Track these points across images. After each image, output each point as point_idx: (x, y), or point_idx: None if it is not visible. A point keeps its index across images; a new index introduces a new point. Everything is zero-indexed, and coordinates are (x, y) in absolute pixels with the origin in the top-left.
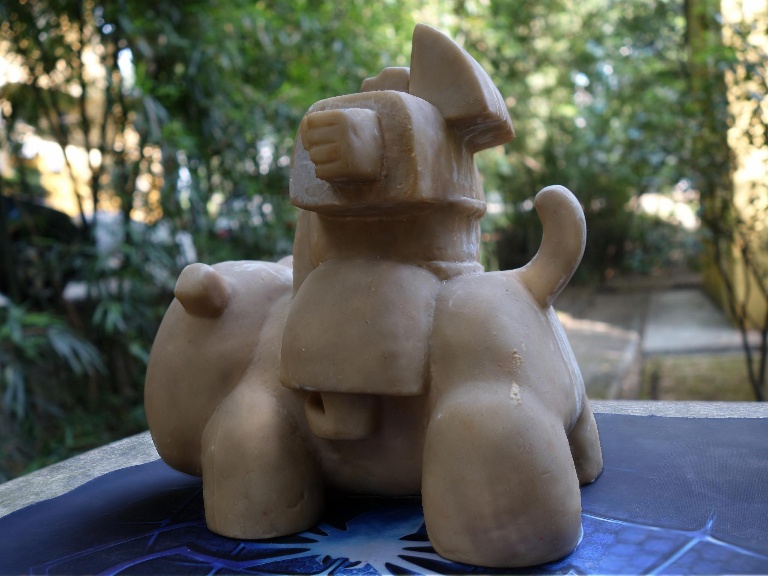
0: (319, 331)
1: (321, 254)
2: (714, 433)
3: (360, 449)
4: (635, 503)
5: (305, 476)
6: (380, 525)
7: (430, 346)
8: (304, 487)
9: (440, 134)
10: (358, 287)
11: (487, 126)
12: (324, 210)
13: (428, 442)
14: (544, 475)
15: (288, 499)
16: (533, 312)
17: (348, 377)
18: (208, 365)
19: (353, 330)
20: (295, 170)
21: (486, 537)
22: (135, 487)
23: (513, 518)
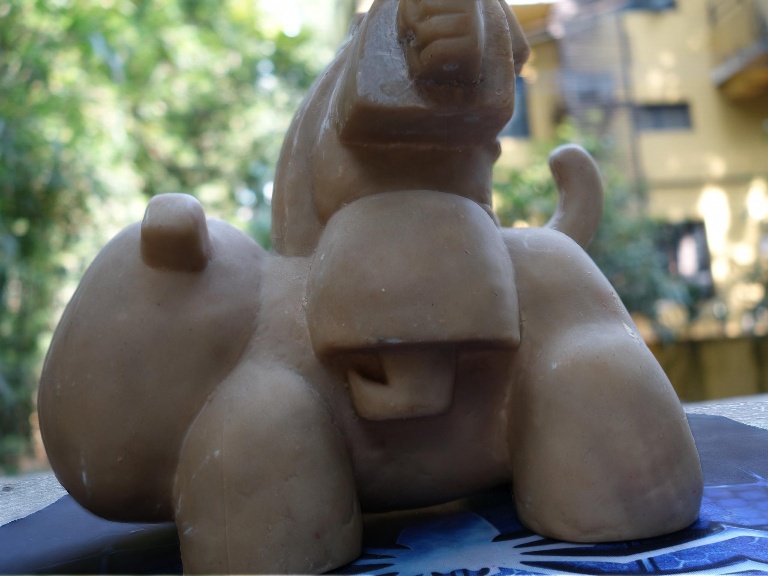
0: (404, 265)
1: (350, 191)
2: None
3: (417, 436)
4: None
5: (351, 480)
6: (445, 536)
7: (518, 290)
8: (353, 495)
9: None
10: (443, 213)
11: None
12: (394, 118)
13: (545, 399)
14: (684, 418)
15: (342, 512)
16: None
17: (453, 320)
18: (194, 336)
19: (452, 261)
20: (366, 61)
21: (643, 499)
22: None
23: (670, 470)
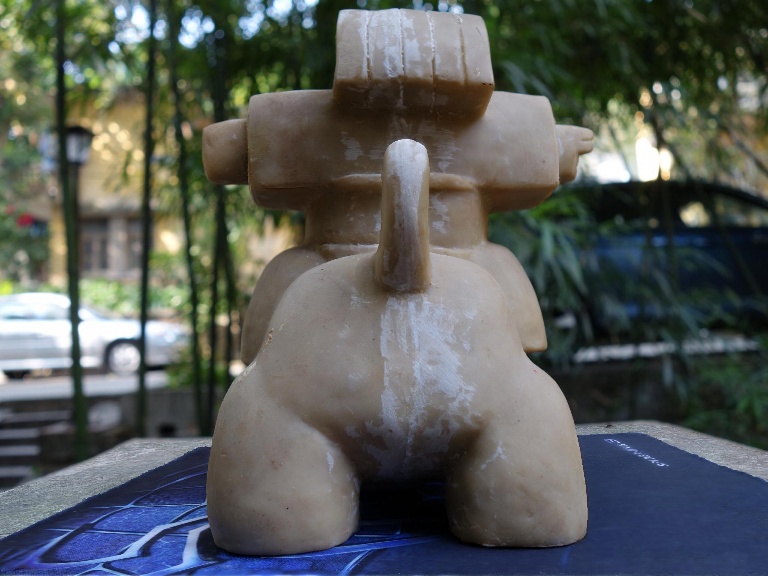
0: None
1: None
2: None
3: None
4: (422, 571)
5: None
6: None
7: None
8: None
9: (308, 119)
10: None
11: (386, 90)
12: None
13: None
14: (222, 454)
15: None
16: (336, 293)
17: None
18: None
19: None
20: None
21: None
22: None
23: None
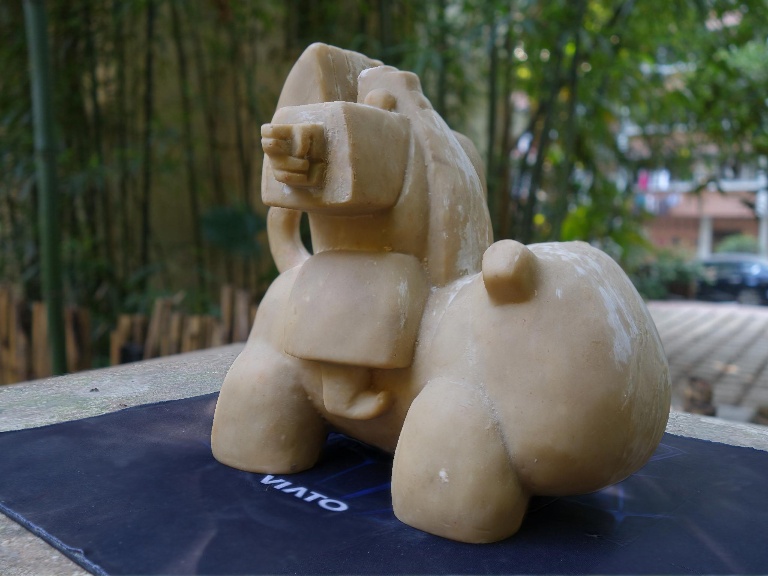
0: None
1: None
2: (46, 458)
3: None
4: None
5: None
6: None
7: None
8: None
9: None
10: None
11: None
12: None
13: None
14: None
15: None
16: None
17: None
18: None
19: None
20: None
21: None
22: (720, 527)
23: None
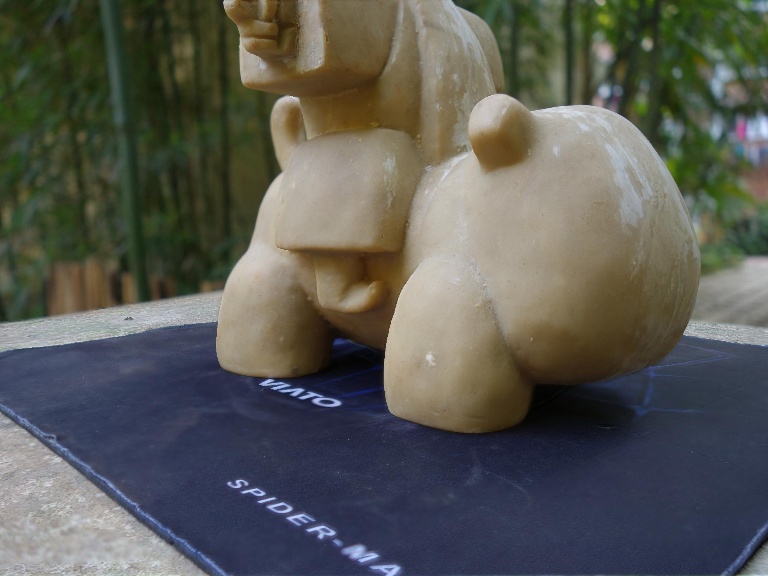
0: None
1: None
2: (57, 367)
3: None
4: None
5: None
6: None
7: None
8: None
9: None
10: None
11: None
12: None
13: None
14: None
15: None
16: None
17: None
18: None
19: None
20: None
21: None
22: (759, 419)
23: None
